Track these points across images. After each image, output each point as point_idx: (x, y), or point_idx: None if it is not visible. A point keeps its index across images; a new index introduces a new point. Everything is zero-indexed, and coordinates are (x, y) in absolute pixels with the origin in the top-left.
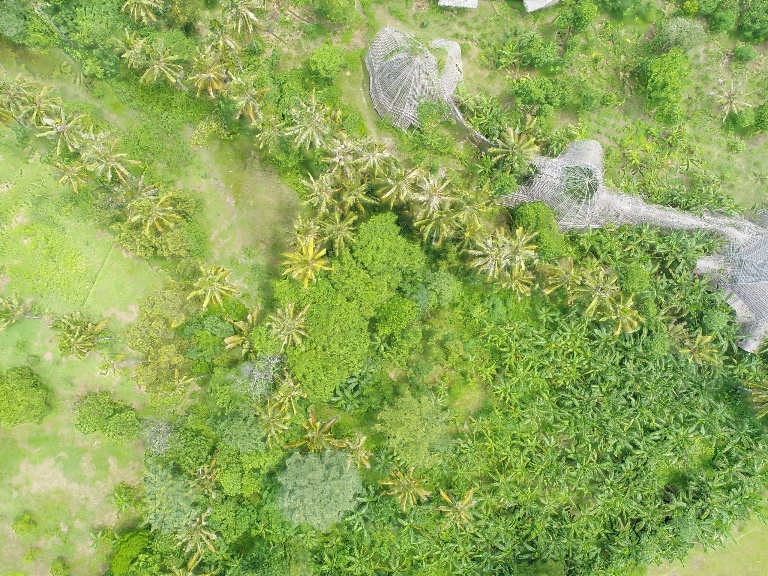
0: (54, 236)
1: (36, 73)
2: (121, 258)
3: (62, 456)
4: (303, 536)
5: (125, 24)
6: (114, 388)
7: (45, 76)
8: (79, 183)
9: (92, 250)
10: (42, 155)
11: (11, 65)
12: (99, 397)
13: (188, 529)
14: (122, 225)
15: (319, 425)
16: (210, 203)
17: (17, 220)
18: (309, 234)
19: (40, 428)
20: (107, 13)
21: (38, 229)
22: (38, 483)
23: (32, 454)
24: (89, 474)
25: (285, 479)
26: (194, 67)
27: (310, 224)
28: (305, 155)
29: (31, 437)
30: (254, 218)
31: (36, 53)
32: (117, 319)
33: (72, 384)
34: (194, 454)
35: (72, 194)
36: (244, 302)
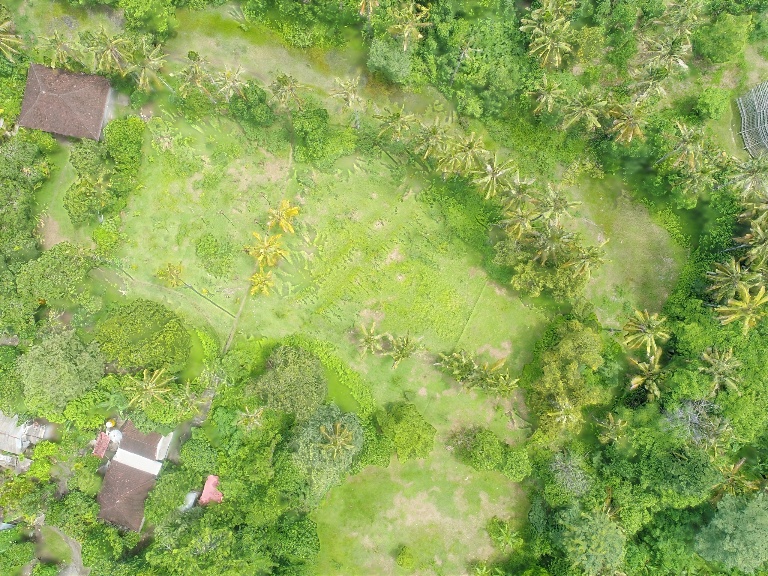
0: (428, 273)
1: (408, 111)
2: (494, 295)
3: (435, 490)
4: (686, 573)
5: (520, 66)
6: (488, 424)
7: (418, 114)
8: (525, 229)
9: (465, 287)
10: (416, 193)
11: (384, 103)
12: (486, 434)
13: (606, 569)
14: (526, 266)
15: (733, 467)
16: (581, 241)
17: (392, 257)
18: (746, 281)
19: (413, 462)
20: (502, 55)
21: (413, 266)
22: (412, 517)
23: (405, 488)
24: (462, 508)
25: (721, 522)
26: (632, 114)
27: (736, 269)
28: (699, 197)
29: (403, 471)
30: (624, 256)
31: (409, 91)
32: (490, 356)
33: (447, 420)
34: (592, 493)
35: (449, 232)
36: (617, 340)
